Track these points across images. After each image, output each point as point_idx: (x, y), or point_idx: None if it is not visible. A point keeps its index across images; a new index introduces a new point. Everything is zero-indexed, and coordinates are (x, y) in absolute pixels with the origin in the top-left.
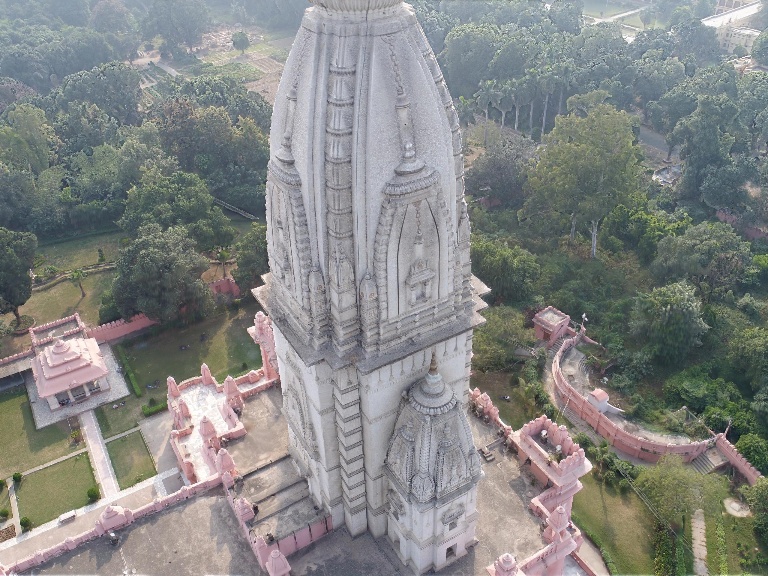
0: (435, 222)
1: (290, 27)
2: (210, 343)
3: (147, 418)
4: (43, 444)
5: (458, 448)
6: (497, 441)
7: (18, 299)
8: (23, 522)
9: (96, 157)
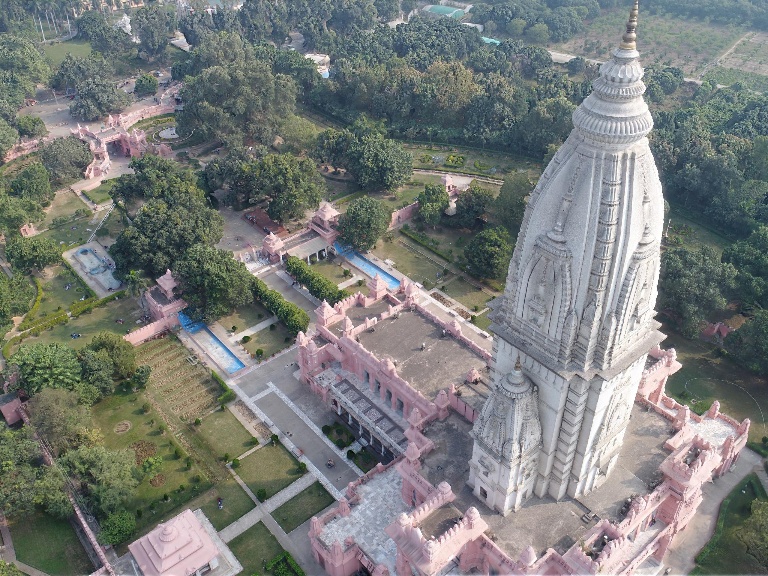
0: (555, 281)
1: None
2: None
3: None
4: None
5: (499, 423)
6: None
7: None
8: (473, 317)
9: None
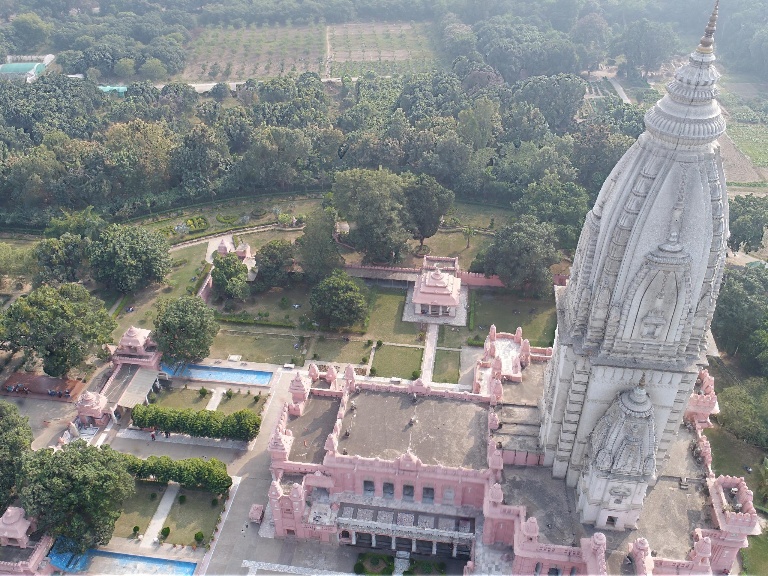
0: (677, 289)
1: (754, 72)
2: (535, 317)
3: (469, 346)
4: (402, 331)
5: (638, 446)
6: (698, 479)
7: (427, 233)
8: (372, 369)
9: (521, 149)
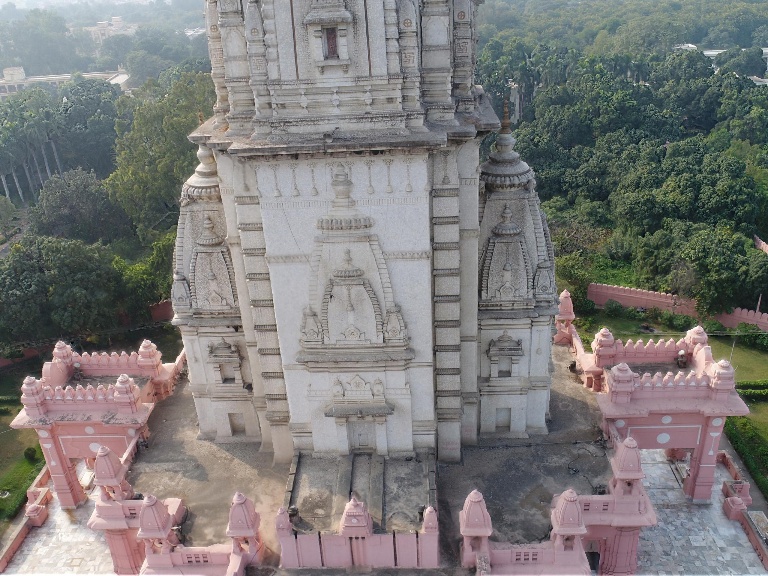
0: None
1: None
2: None
3: None
4: None
5: None
6: None
7: None
8: None
9: None
